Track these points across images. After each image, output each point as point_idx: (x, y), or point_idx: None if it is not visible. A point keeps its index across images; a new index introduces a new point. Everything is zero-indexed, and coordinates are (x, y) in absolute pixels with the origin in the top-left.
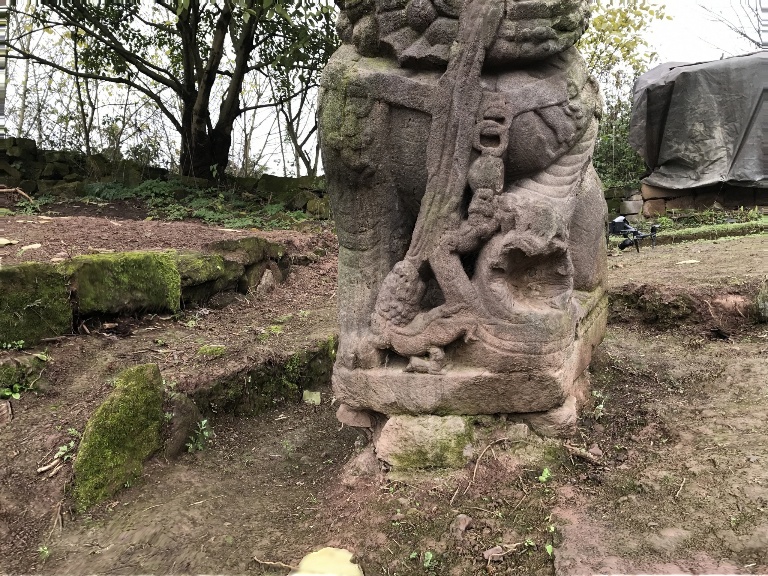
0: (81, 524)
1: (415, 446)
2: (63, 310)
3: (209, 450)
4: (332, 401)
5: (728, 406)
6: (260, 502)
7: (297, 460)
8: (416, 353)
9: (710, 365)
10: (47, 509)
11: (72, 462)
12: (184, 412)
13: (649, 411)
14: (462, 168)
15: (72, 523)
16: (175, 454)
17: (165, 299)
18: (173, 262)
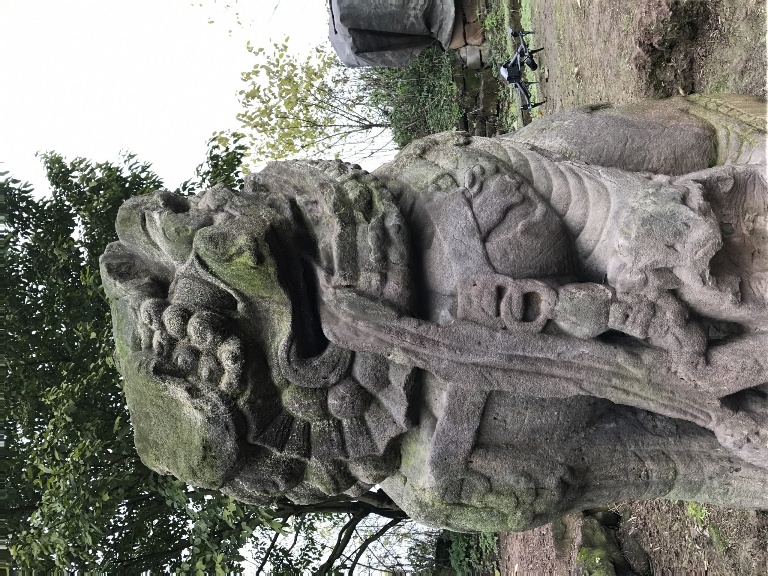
0: None
1: None
2: None
3: None
4: None
5: None
6: None
7: None
8: None
9: None
10: None
11: None
12: None
13: None
14: (573, 347)
15: None
16: None
17: None
18: None
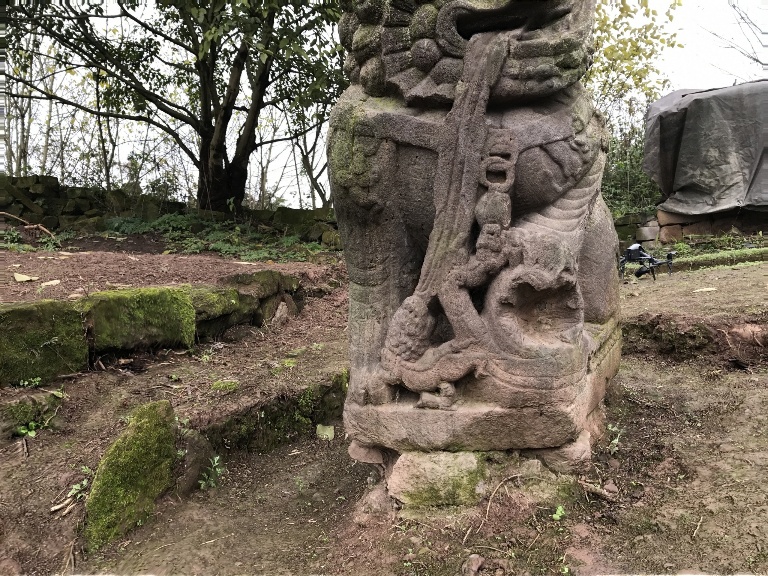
0: (93, 564)
1: (427, 483)
2: (79, 347)
3: (222, 487)
4: (346, 435)
5: (747, 440)
6: (272, 541)
7: (310, 497)
8: (427, 389)
9: (728, 397)
10: (60, 549)
11: (85, 501)
12: (197, 449)
13: (666, 446)
14: (469, 204)
15: (84, 563)
16: (188, 491)
17: (180, 334)
18: (188, 297)
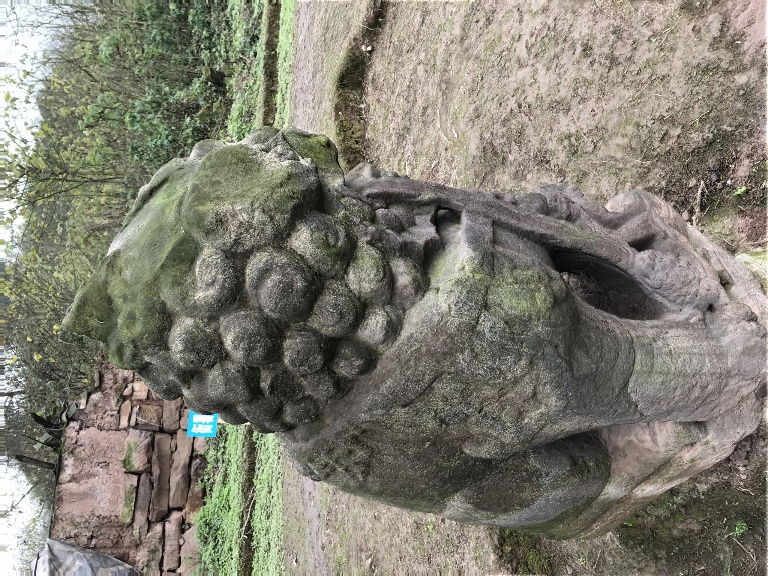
0: None
1: None
2: None
3: None
4: None
5: None
6: None
7: None
8: None
9: None
10: None
11: None
12: None
13: None
14: (533, 213)
15: None
16: None
17: None
18: None
